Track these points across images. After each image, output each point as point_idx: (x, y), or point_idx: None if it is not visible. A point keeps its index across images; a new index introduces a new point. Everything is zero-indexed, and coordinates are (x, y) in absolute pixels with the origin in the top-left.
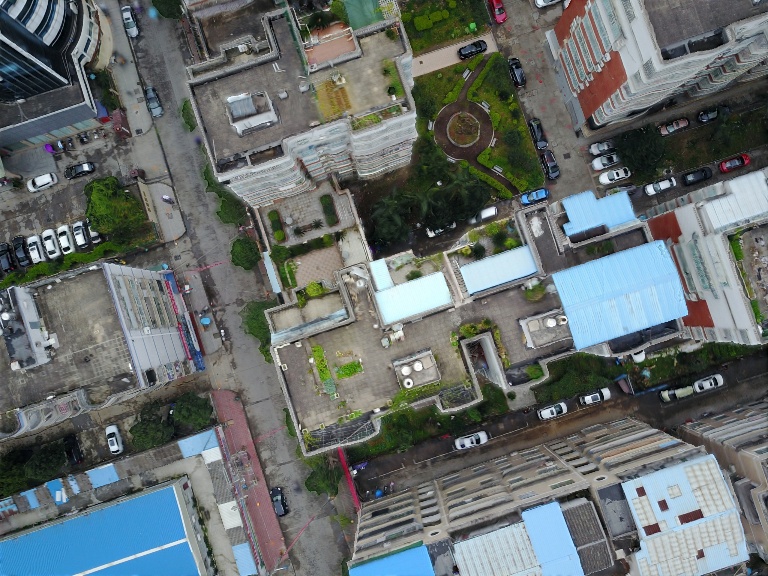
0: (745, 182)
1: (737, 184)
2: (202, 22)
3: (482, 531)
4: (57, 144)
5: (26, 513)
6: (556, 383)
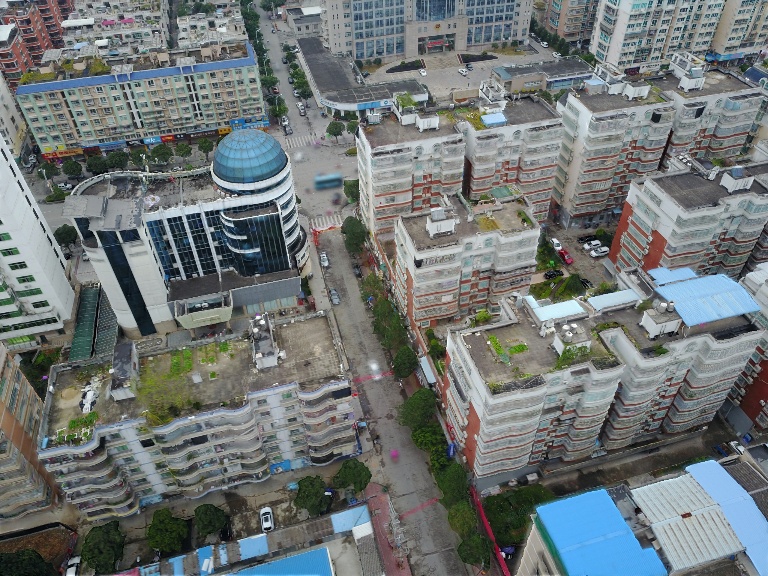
0: (767, 265)
1: (762, 266)
2: (381, 243)
3: None
4: None
5: None
6: None
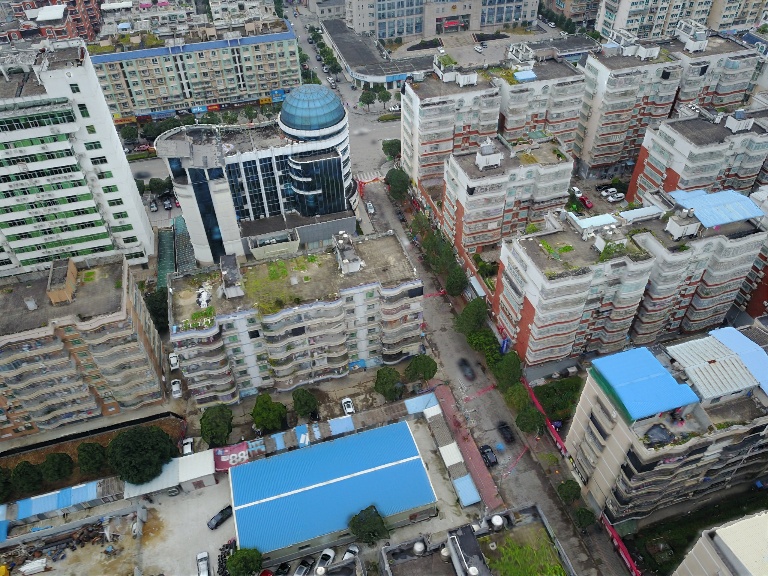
0: (767, 187)
1: (764, 188)
2: None
3: None
4: None
5: None
6: None
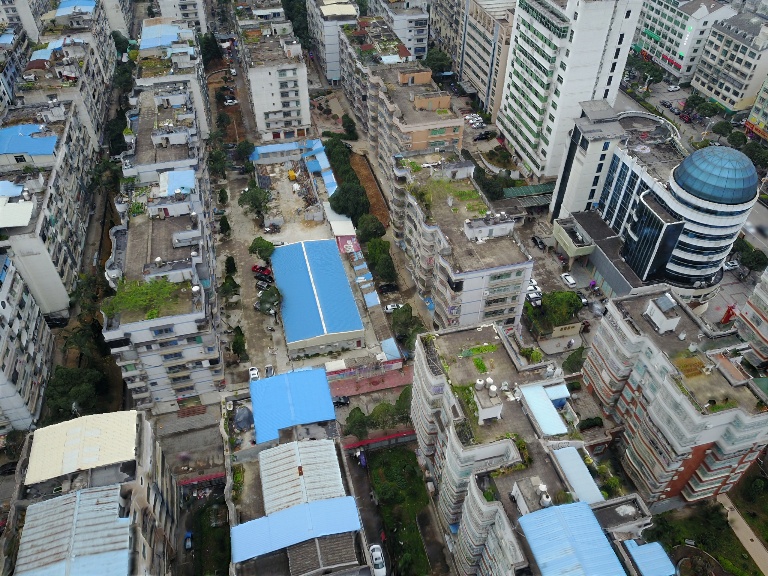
0: None
1: None
2: None
3: None
4: (597, 287)
5: (349, 268)
6: None
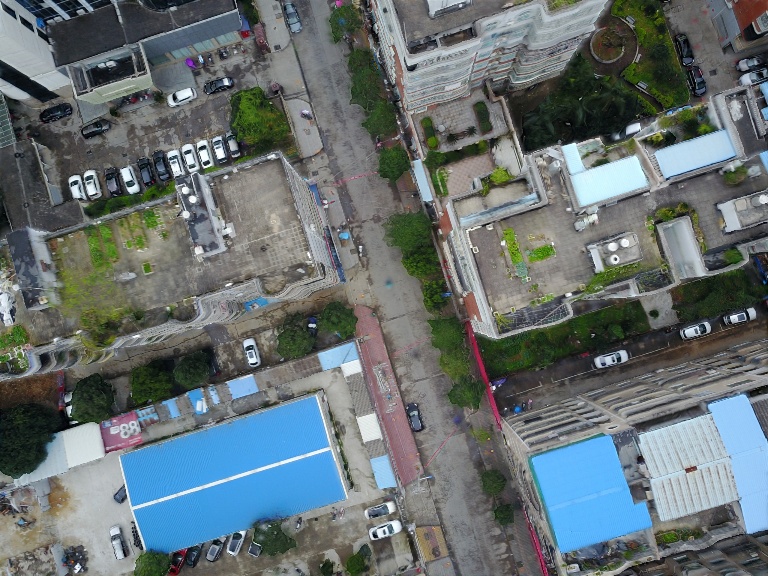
0: None
1: None
2: None
3: (663, 425)
4: (198, 58)
5: (164, 424)
6: (701, 302)
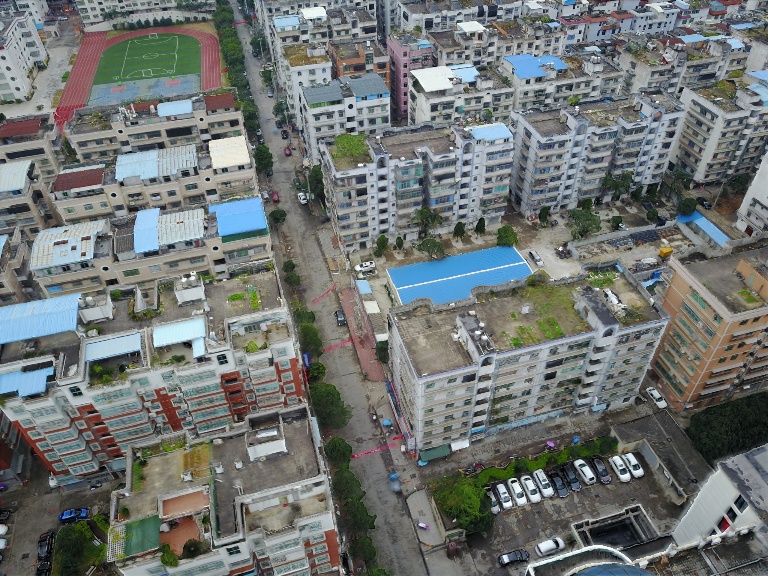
0: None
1: None
2: None
3: (187, 248)
4: None
5: None
6: None
